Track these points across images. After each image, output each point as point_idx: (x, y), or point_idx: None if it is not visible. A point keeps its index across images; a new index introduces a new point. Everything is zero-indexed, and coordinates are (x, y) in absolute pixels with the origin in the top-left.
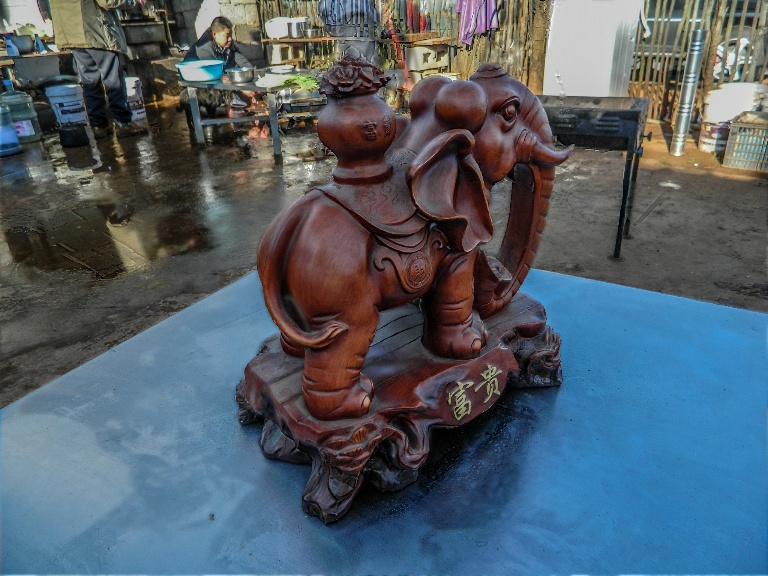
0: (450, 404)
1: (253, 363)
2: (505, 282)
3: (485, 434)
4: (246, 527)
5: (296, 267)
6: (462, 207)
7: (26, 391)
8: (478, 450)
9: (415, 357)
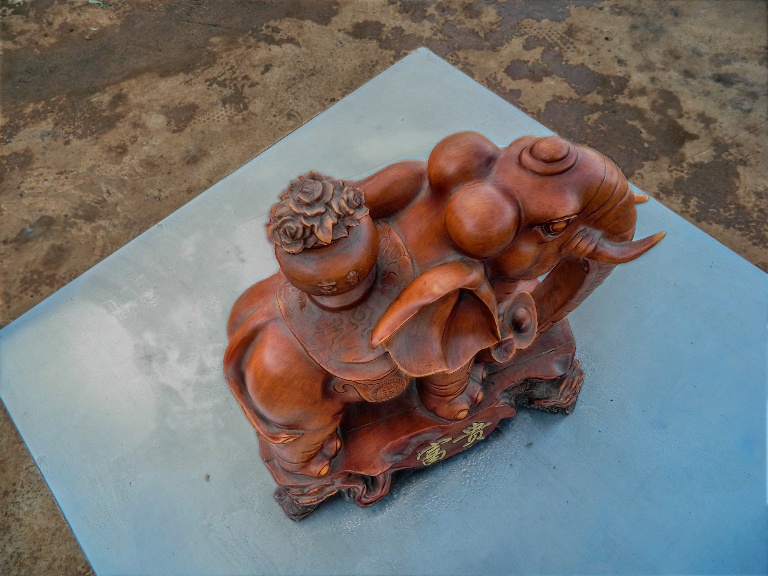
0: (419, 459)
1: None
2: (520, 349)
3: (463, 458)
4: (230, 498)
5: (248, 385)
6: (465, 314)
7: (135, 130)
8: (447, 477)
9: (401, 399)
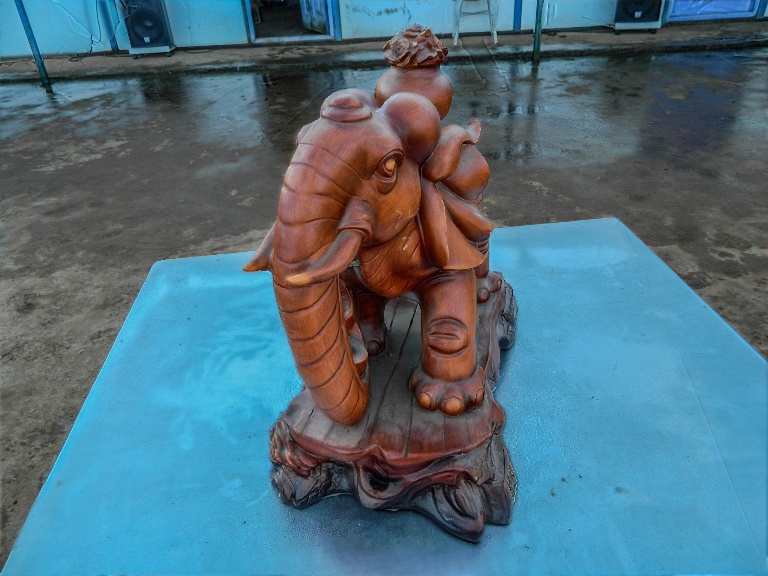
0: None
1: None
2: None
3: None
4: None
5: None
6: None
7: None
8: None
9: None
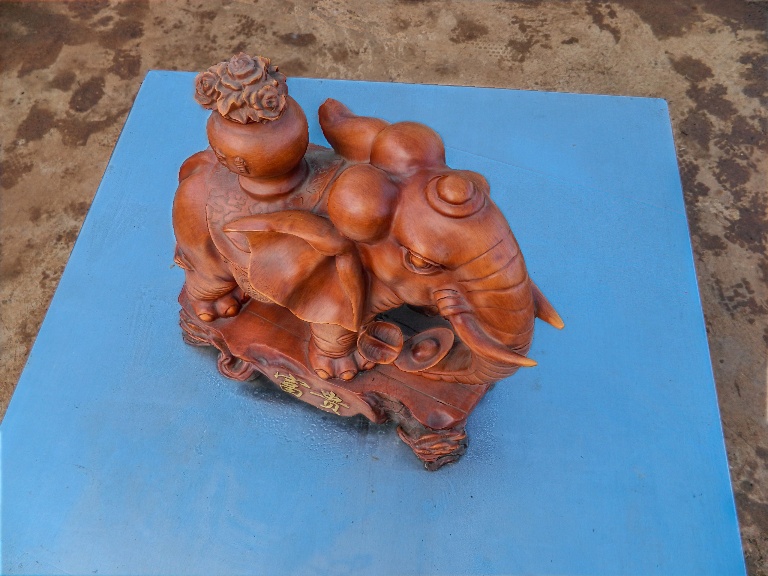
0: (277, 378)
1: None
2: None
3: (323, 417)
4: (170, 291)
5: None
6: (341, 284)
7: (426, 18)
8: (299, 417)
9: (304, 325)
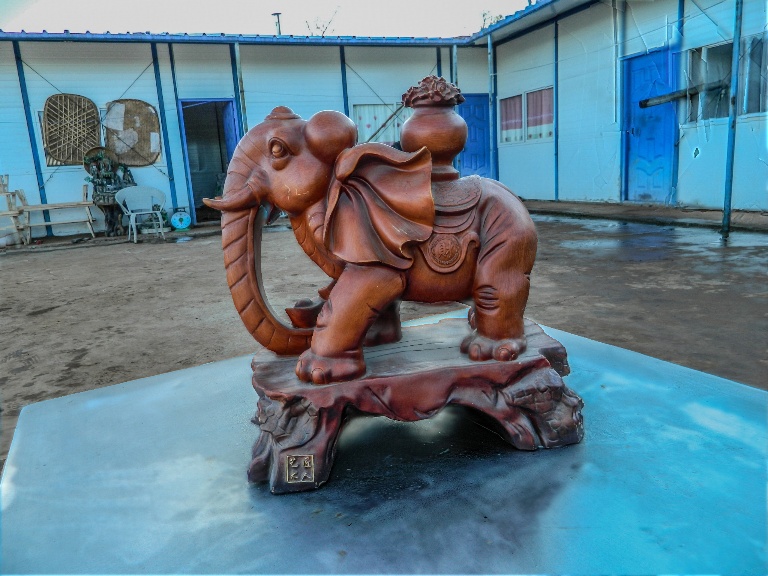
0: None
1: (557, 343)
2: None
3: None
4: None
5: None
6: None
7: None
8: None
9: (417, 334)
